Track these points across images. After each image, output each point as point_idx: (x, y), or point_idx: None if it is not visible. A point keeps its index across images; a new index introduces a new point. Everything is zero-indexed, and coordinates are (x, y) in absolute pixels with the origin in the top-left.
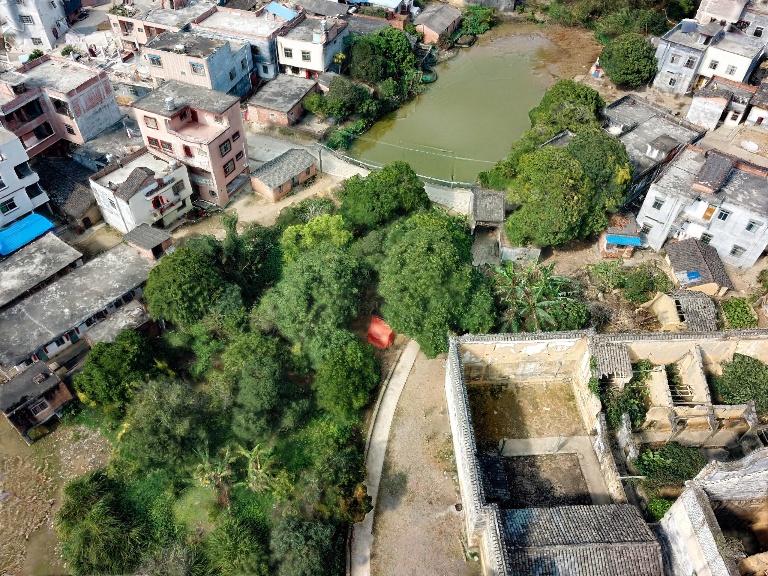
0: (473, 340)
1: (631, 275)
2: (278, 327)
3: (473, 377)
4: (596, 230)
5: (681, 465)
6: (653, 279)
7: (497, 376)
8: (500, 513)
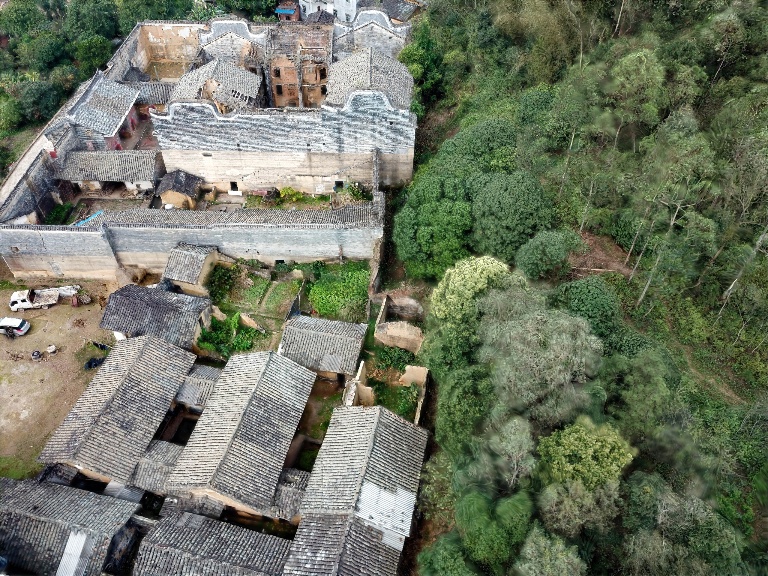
0: (148, 22)
1: None
2: (65, 33)
3: (161, 56)
4: (270, 5)
5: None
6: None
7: (174, 56)
8: None
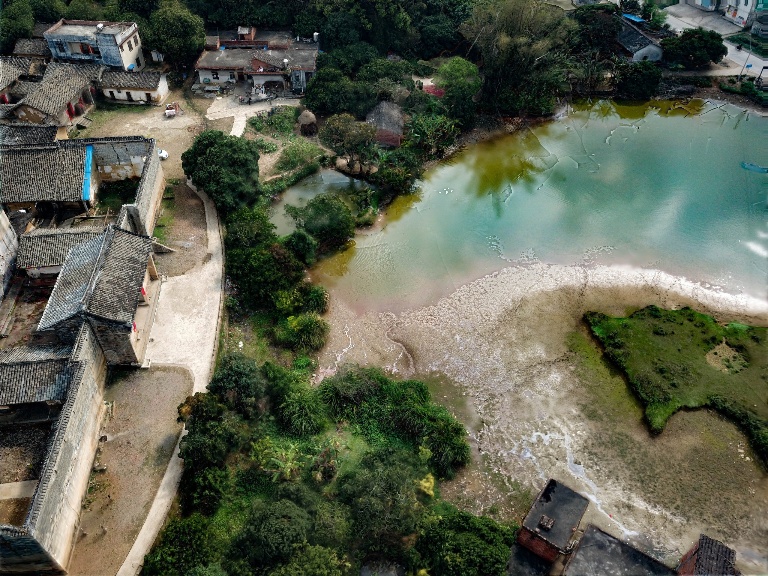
0: (3, 525)
1: None
2: None
3: None
4: None
5: None
6: None
7: None
8: None
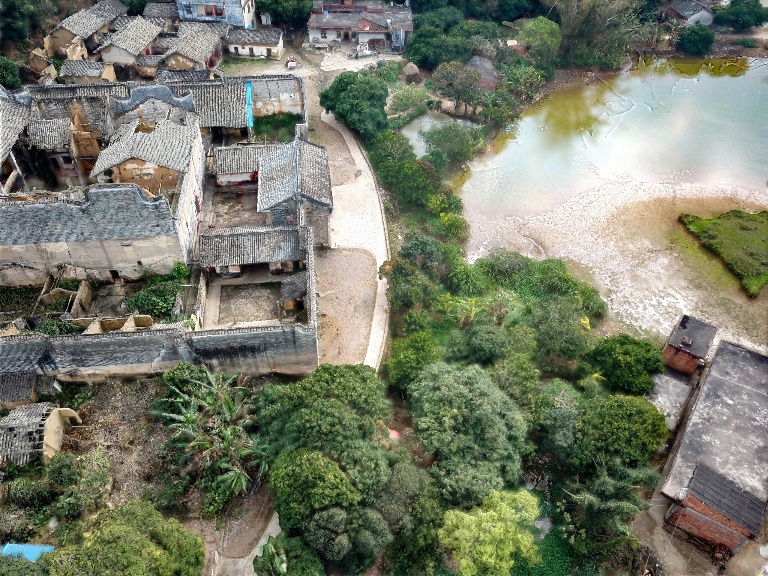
0: None
1: (68, 467)
2: None
3: None
4: None
5: (148, 294)
6: (28, 497)
7: None
8: (293, 257)
